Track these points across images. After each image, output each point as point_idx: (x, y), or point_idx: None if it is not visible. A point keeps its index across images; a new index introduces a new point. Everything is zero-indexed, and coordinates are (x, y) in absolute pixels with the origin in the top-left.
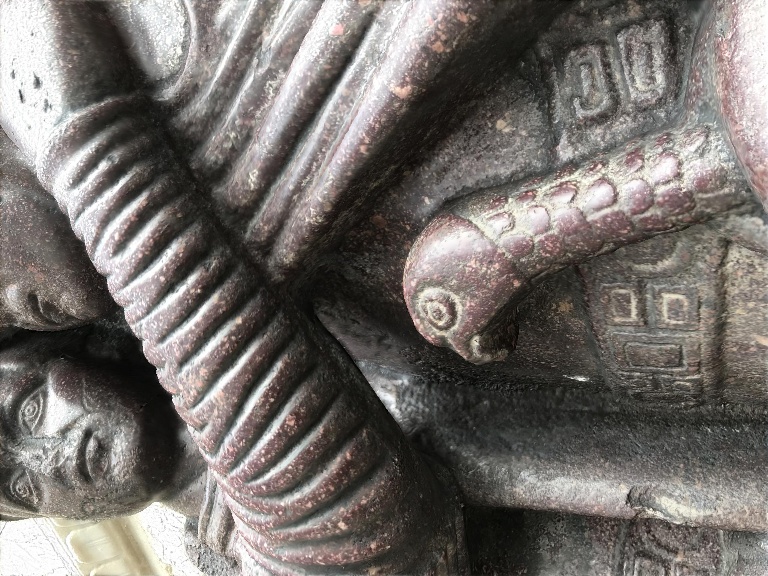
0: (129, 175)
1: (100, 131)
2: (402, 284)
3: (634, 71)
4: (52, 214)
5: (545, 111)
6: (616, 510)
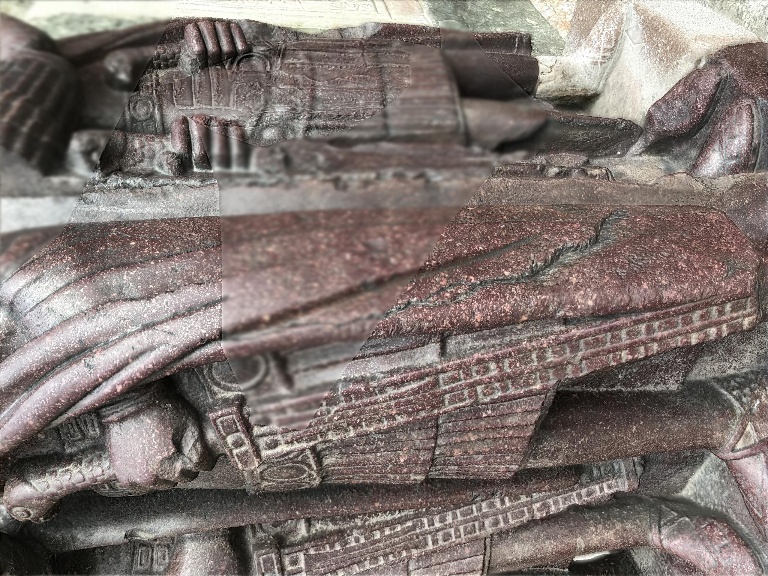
0: None
1: None
2: (2, 481)
3: (88, 428)
4: None
5: None
6: (121, 542)
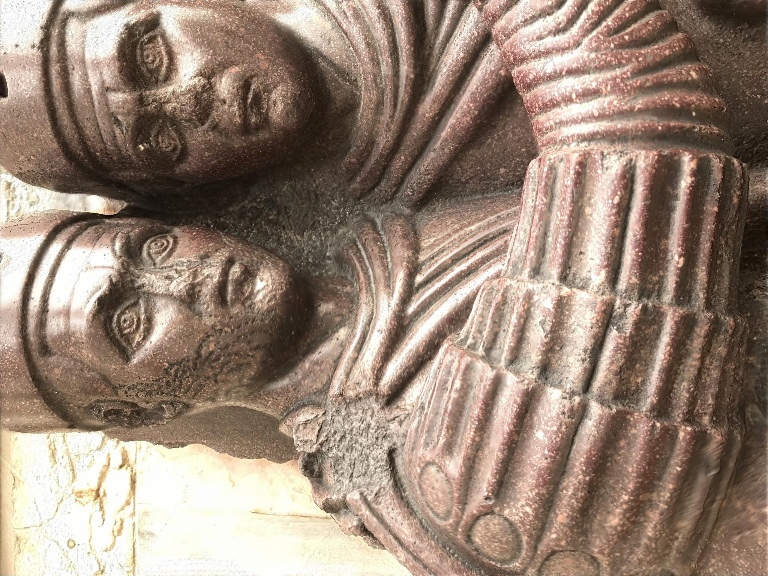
0: None
1: None
2: None
3: None
4: (280, 29)
5: None
6: None
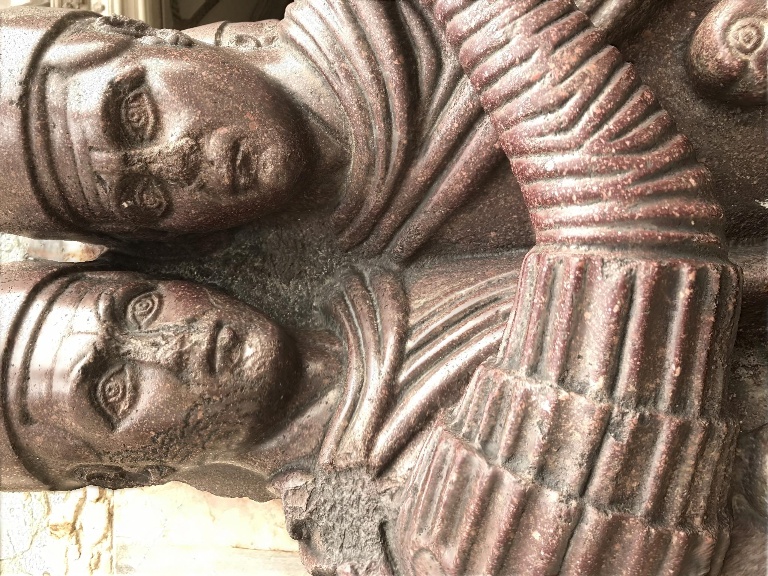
0: None
1: None
2: None
3: None
4: (269, 85)
5: None
6: None
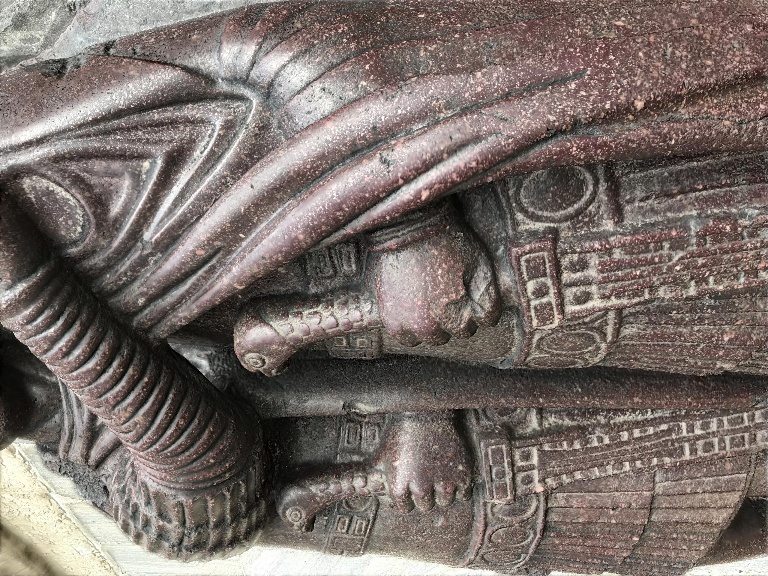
0: (65, 314)
1: (42, 292)
2: (222, 326)
3: (343, 262)
4: None
5: (303, 268)
6: (338, 413)
